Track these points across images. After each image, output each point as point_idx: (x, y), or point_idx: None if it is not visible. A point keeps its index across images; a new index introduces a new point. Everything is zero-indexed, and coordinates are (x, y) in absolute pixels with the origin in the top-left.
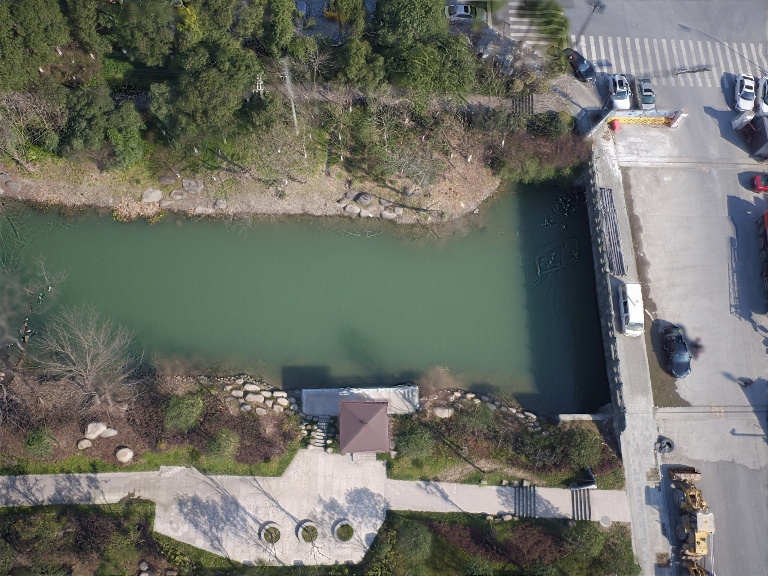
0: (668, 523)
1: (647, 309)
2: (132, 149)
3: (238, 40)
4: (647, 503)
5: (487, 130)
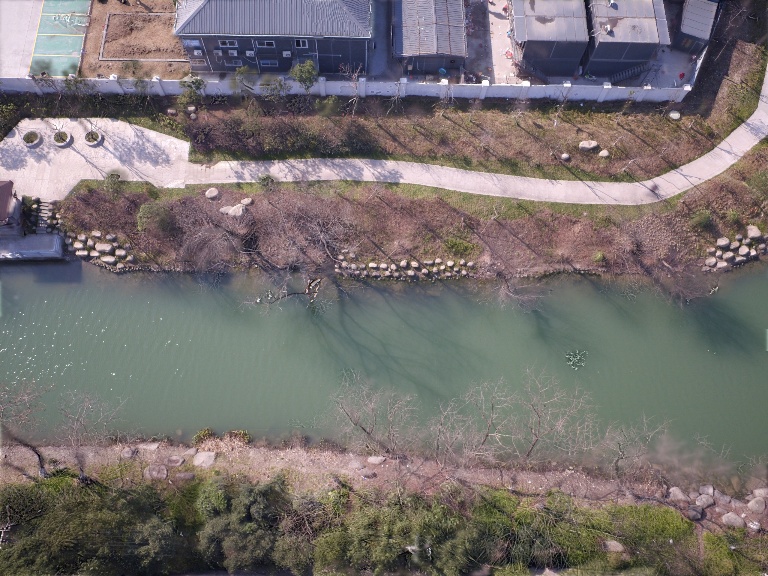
0: None
1: None
2: None
3: None
4: None
5: None
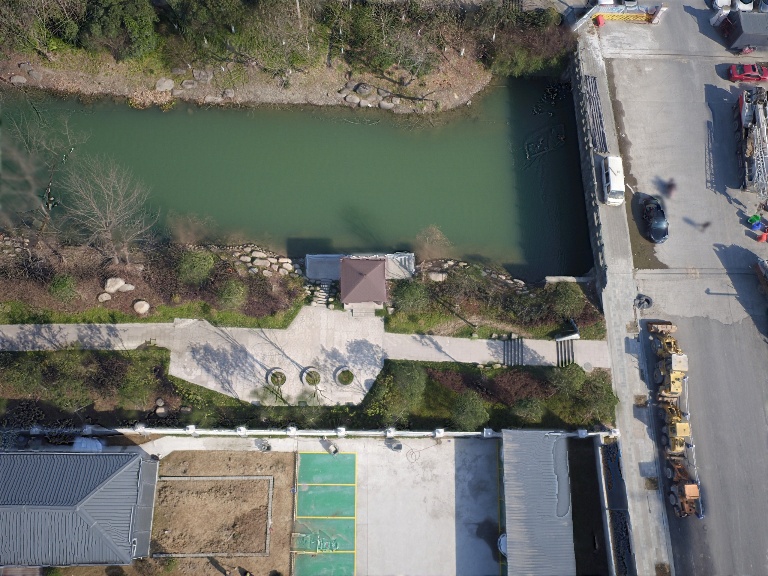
0: (646, 370)
1: (628, 183)
2: (146, 37)
3: None
4: (627, 352)
5: (479, 25)
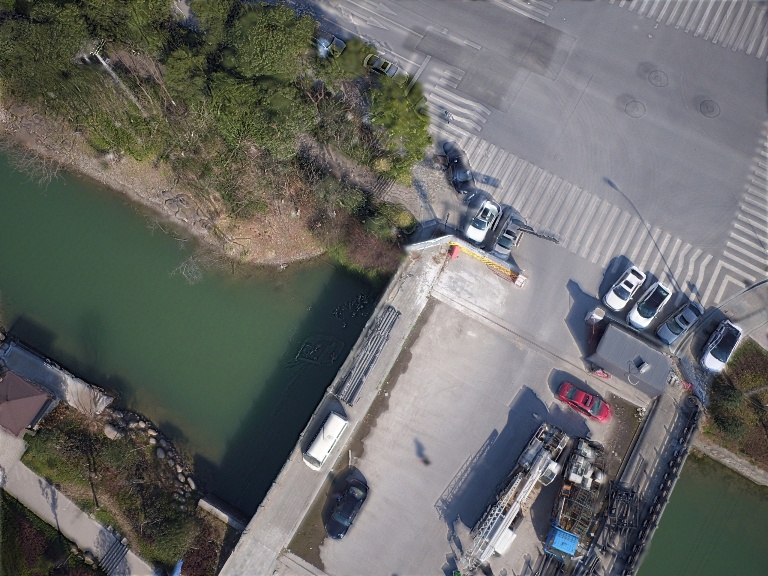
0: None
1: (351, 450)
2: (7, 60)
3: (106, 0)
4: None
5: (328, 193)
